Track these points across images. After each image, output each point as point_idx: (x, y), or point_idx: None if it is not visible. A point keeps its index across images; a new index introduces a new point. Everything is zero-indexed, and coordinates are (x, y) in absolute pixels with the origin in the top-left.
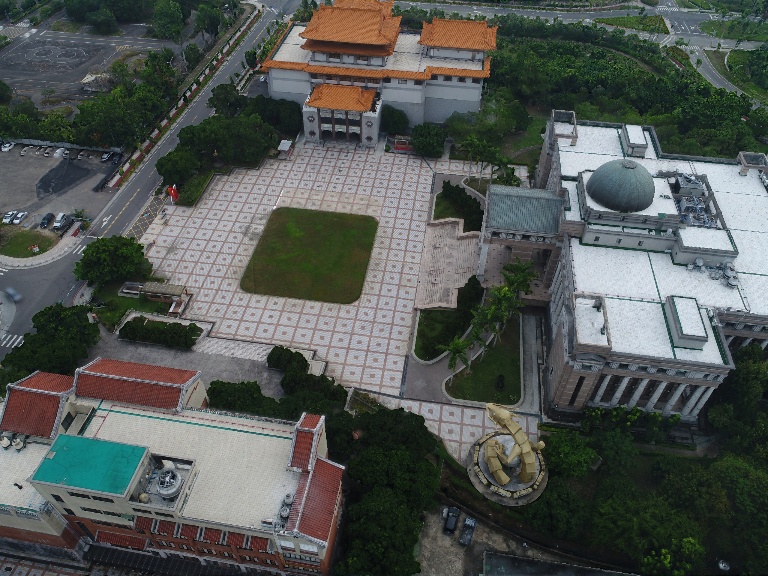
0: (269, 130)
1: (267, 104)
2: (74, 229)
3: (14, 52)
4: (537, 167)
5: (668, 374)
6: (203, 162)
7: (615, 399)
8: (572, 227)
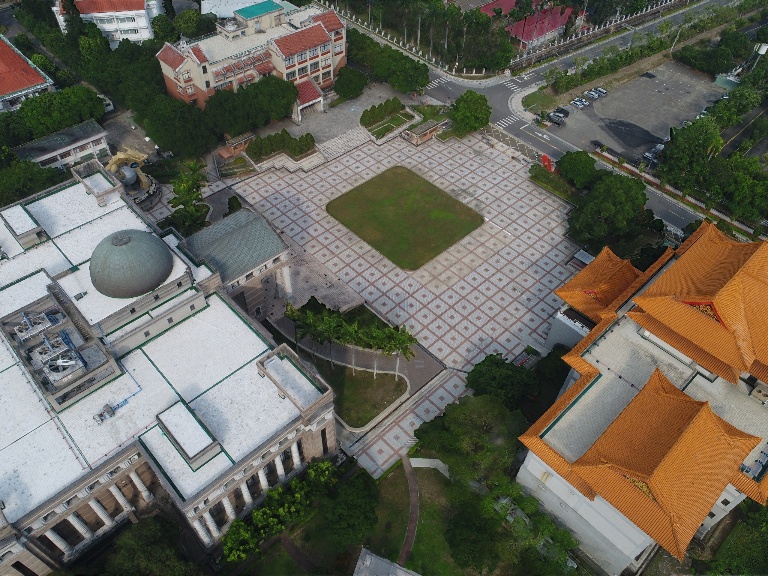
0: None
1: None
2: None
3: None
4: None
5: None
6: None
7: None
8: None
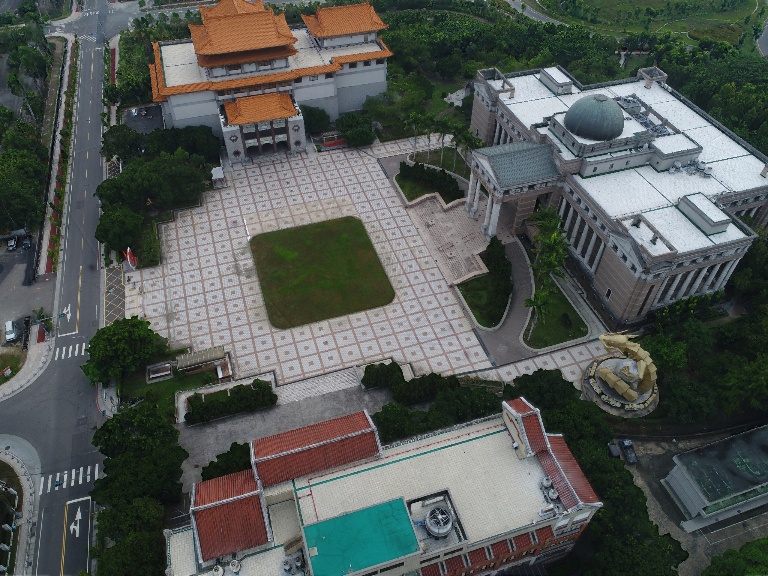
0: (199, 161)
1: (176, 135)
2: (35, 334)
3: None
4: (469, 128)
5: (711, 259)
6: (140, 215)
7: (669, 297)
8: (572, 165)
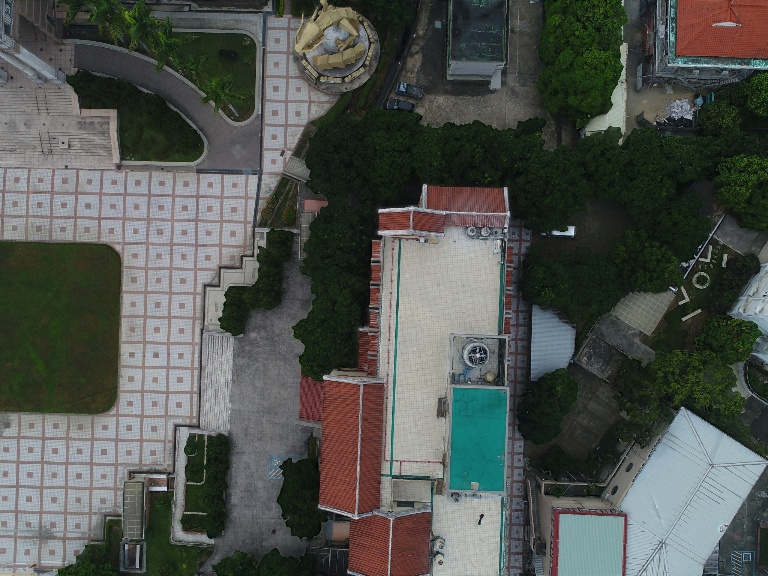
0: None
1: None
2: None
3: None
4: None
5: None
6: None
7: None
8: None
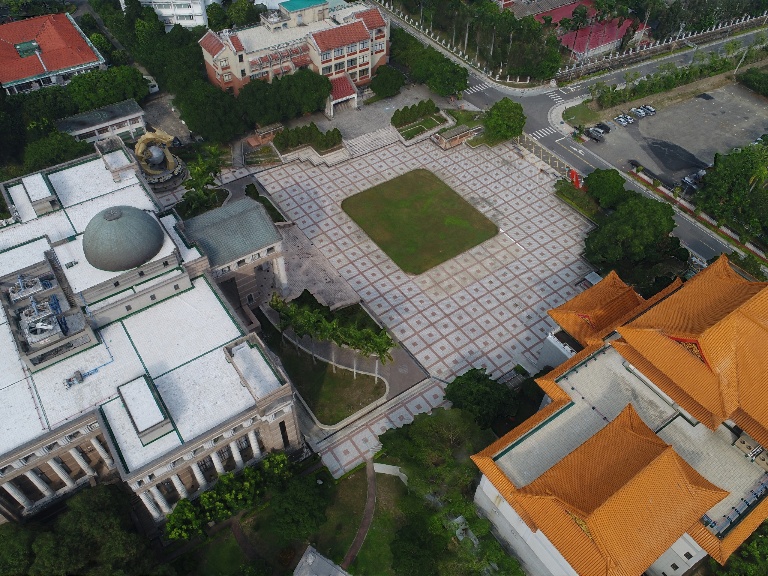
0: None
1: None
2: None
3: None
4: None
5: None
6: None
7: None
8: None
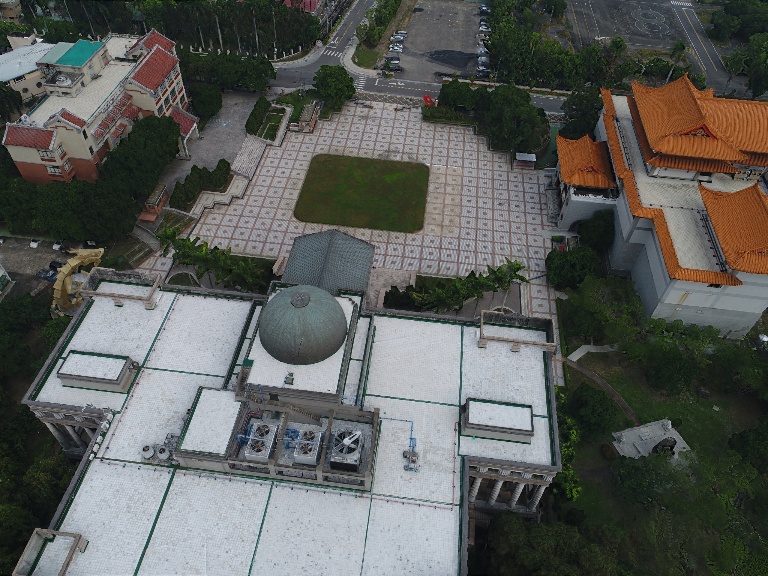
0: None
1: None
2: (386, 72)
3: (640, 4)
4: None
5: None
6: (480, 112)
7: None
8: None
